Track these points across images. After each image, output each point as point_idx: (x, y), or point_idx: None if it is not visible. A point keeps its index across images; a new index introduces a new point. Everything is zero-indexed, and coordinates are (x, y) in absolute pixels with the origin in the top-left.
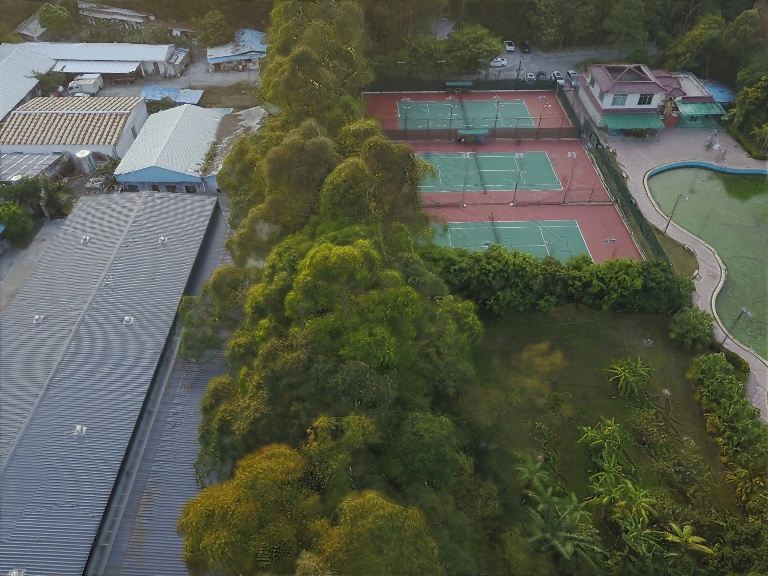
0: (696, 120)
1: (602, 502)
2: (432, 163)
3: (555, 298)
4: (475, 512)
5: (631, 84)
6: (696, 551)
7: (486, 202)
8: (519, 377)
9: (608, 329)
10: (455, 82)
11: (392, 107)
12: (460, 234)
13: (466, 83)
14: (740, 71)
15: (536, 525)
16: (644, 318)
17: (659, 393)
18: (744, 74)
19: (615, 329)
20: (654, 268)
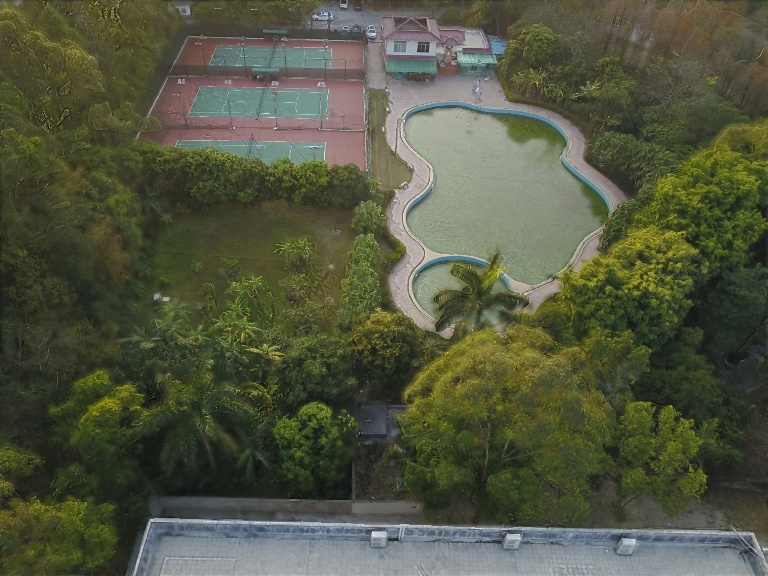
0: (476, 69)
1: (212, 327)
2: (222, 94)
3: (253, 190)
4: (35, 296)
5: (409, 33)
6: (271, 360)
7: (254, 126)
8: (214, 253)
9: (308, 222)
10: (272, 30)
11: (209, 49)
12: (219, 149)
13: (281, 31)
14: (509, 26)
15: (138, 334)
16: (343, 215)
17: (324, 267)
18: (512, 28)
19: (314, 222)
20: (344, 170)
